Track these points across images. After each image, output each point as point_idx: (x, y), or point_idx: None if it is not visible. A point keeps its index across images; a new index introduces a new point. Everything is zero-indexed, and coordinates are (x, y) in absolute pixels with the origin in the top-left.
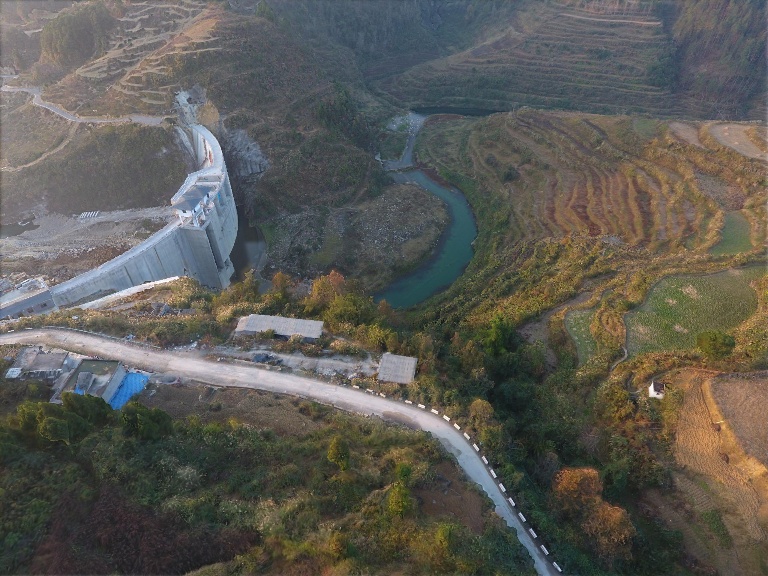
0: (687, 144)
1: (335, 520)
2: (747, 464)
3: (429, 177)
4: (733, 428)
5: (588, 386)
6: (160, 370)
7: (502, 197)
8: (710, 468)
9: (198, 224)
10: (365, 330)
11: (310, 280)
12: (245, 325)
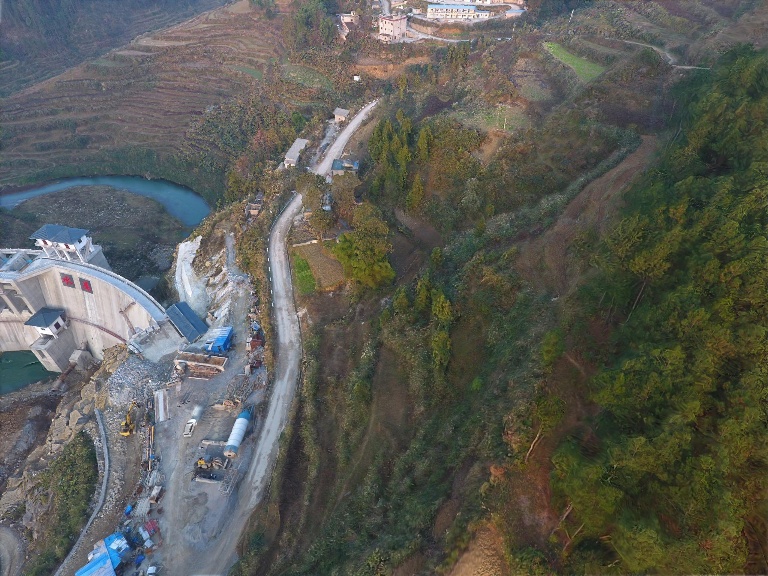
0: (150, 55)
1: (423, 88)
2: (389, 68)
3: (19, 192)
4: (378, 64)
5: (345, 97)
6: (325, 175)
7: (108, 150)
8: (388, 75)
9: (92, 248)
10: (309, 125)
11: (154, 250)
12: (293, 159)
